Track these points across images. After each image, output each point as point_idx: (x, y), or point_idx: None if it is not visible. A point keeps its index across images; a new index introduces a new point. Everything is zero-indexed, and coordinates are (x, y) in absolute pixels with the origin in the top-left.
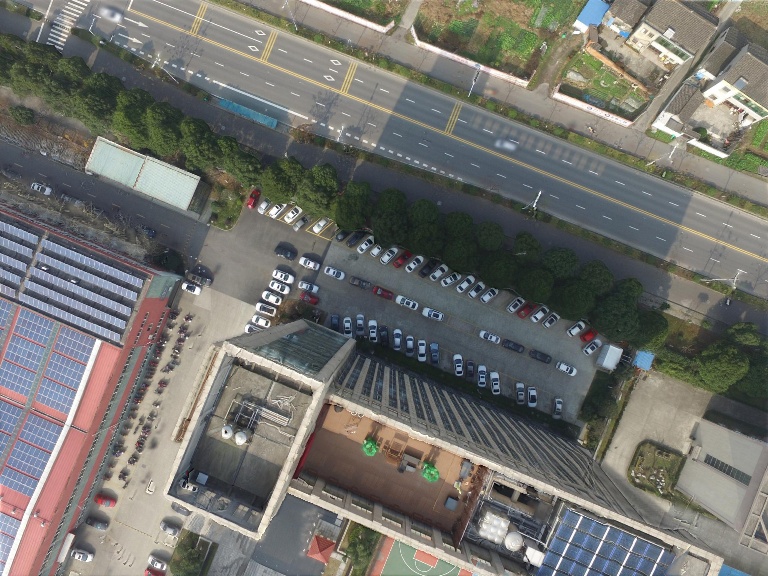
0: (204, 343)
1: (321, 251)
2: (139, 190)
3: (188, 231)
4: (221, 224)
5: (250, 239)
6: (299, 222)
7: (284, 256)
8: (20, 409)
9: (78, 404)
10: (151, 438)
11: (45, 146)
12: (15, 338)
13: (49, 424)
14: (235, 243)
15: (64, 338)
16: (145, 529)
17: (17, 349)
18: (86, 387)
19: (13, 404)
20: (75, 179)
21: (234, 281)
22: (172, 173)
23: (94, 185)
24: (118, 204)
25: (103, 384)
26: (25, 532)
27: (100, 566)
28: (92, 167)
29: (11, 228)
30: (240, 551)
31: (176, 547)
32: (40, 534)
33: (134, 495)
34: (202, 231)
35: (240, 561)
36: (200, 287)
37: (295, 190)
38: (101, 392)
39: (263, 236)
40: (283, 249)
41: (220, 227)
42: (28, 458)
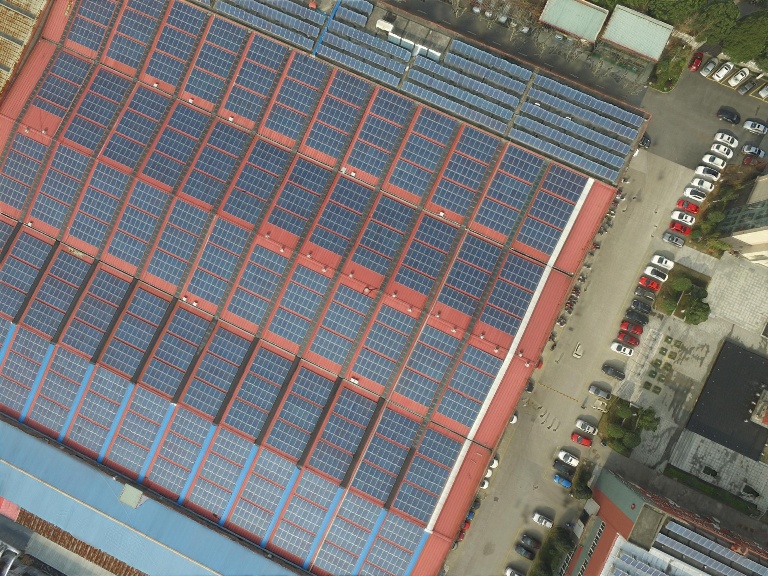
0: (638, 206)
1: (766, 116)
2: (608, 38)
3: (624, 92)
4: (660, 86)
5: (689, 102)
6: (748, 84)
7: (730, 119)
8: (499, 248)
9: (563, 245)
10: (580, 301)
11: (481, 2)
12: (499, 175)
13: (530, 264)
14: (673, 106)
15: (553, 176)
16: (571, 393)
17: (501, 187)
18: (572, 228)
19: (492, 243)
20: (507, 37)
21: (672, 144)
22: (643, 22)
23: (526, 44)
24: (550, 63)
25: (591, 225)
26: (506, 372)
27: (522, 429)
28: (546, 18)
29: (503, 63)
30: (672, 420)
31: (604, 413)
32: (522, 375)
33: (560, 358)
34: (639, 93)
35: (672, 430)
36: (638, 148)
37: (767, 45)
38: (588, 233)
39: (703, 100)
40: (729, 112)
41: (659, 89)
42: (510, 297)
